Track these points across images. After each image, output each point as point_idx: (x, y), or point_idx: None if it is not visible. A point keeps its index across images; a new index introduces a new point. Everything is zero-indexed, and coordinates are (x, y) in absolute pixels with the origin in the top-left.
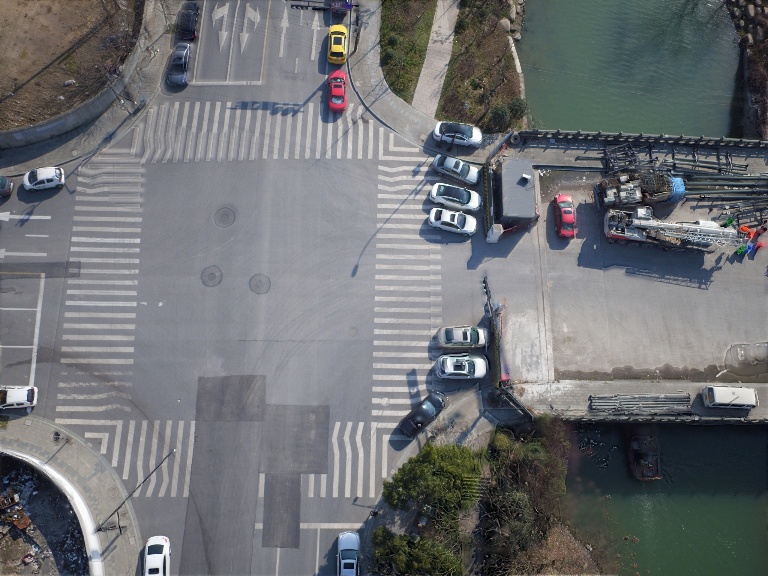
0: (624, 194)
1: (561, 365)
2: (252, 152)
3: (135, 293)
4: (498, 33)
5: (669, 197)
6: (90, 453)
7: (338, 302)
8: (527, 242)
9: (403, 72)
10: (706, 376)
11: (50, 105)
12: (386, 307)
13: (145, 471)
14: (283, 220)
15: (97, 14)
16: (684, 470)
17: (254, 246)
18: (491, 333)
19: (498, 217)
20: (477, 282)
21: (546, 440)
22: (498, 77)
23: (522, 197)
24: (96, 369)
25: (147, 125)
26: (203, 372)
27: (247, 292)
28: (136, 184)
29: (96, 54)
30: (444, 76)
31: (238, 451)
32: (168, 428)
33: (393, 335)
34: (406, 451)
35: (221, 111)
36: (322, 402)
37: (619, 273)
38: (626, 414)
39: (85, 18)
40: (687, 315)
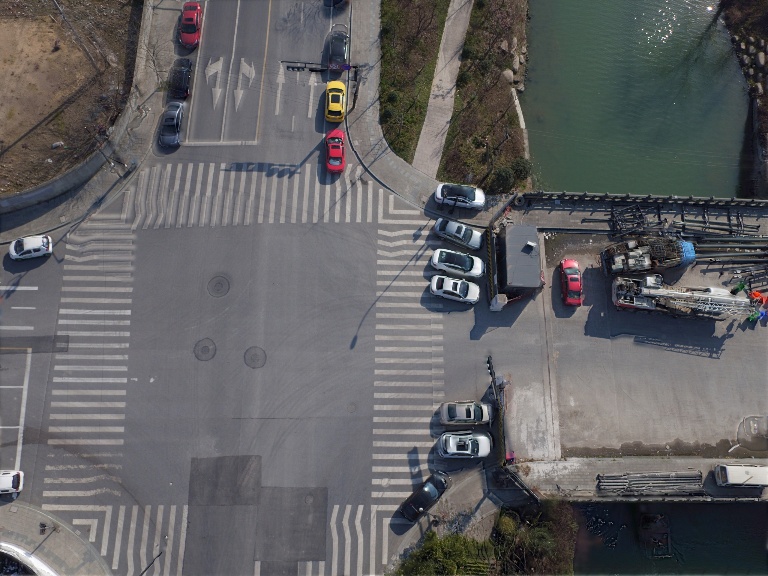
0: (633, 261)
1: (568, 441)
2: (247, 216)
3: (125, 368)
4: (501, 85)
5: (679, 263)
6: (78, 541)
7: (336, 376)
8: (532, 310)
9: (403, 130)
10: (718, 451)
11: (37, 169)
12: (386, 381)
13: (136, 560)
14: (279, 289)
15: (86, 71)
16: (695, 548)
17: (249, 317)
18: (495, 409)
19: (502, 286)
20: (480, 353)
21: (553, 524)
22: (501, 134)
23: (527, 265)
24: (85, 450)
25: (138, 188)
26: (196, 453)
27: (242, 366)
28: (127, 252)
29: (85, 114)
30: (446, 134)
31: (232, 537)
32: (160, 513)
33: (393, 411)
34: (407, 536)
35: (215, 173)
36: (320, 484)
37: (627, 342)
38: (636, 495)
39: (74, 76)
40: (698, 386)
